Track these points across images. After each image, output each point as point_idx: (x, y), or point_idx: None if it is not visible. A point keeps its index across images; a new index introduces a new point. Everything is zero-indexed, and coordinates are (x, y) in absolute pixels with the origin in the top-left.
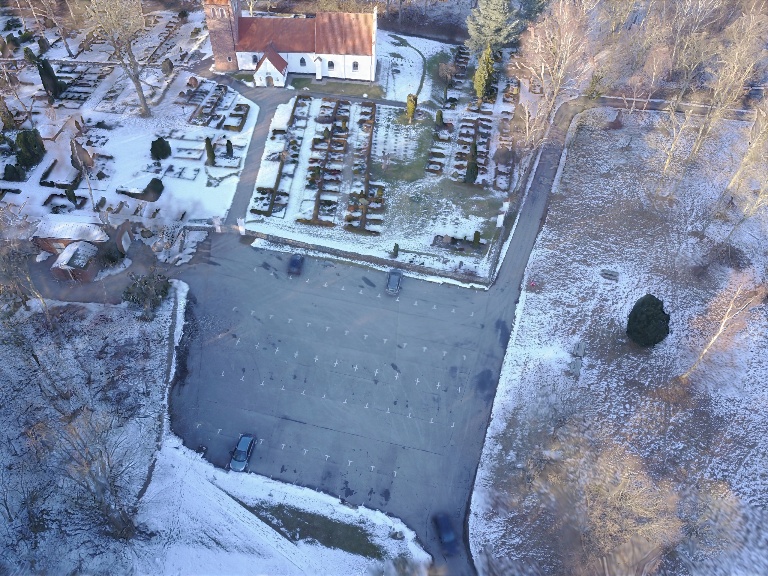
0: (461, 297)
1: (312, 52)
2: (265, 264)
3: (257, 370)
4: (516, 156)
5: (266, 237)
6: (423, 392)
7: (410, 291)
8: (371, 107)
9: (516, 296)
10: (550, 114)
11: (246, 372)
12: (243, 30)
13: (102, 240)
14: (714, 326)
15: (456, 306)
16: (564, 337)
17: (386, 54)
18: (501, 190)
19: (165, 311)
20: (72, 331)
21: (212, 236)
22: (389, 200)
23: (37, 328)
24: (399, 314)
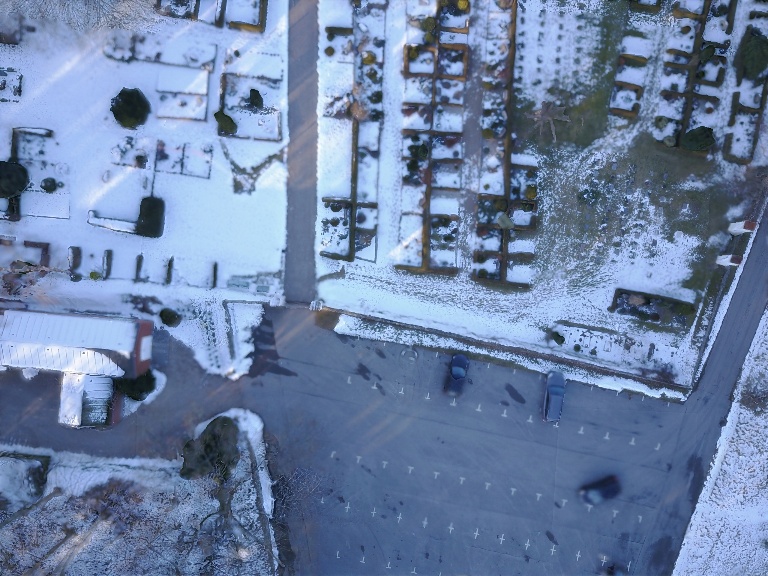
0: (646, 416)
1: None
2: (362, 368)
3: (379, 549)
4: None
5: (356, 315)
6: (585, 572)
7: (574, 407)
8: None
9: (724, 412)
10: None
11: (366, 551)
12: None
13: (115, 375)
14: None
15: (637, 433)
16: None
17: None
18: (737, 161)
19: (242, 473)
20: (131, 518)
21: (271, 314)
22: (545, 202)
23: (84, 515)
24: (558, 451)
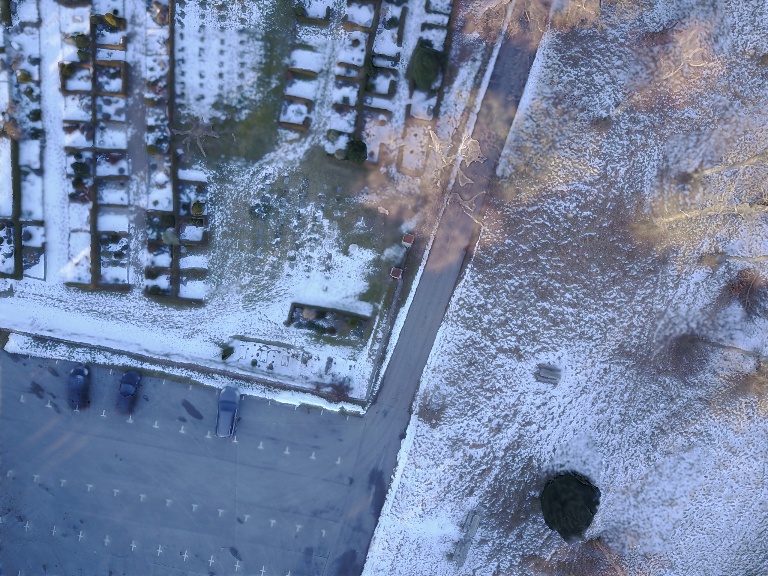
0: (325, 430)
1: None
2: (34, 387)
3: (61, 568)
4: (449, 67)
5: (23, 334)
6: None
7: (253, 422)
8: None
9: (403, 425)
10: None
11: (48, 570)
12: None
13: None
14: (671, 441)
15: (317, 447)
16: (456, 502)
17: None
18: (410, 174)
19: None
20: None
21: None
22: (216, 218)
23: None
24: (237, 467)
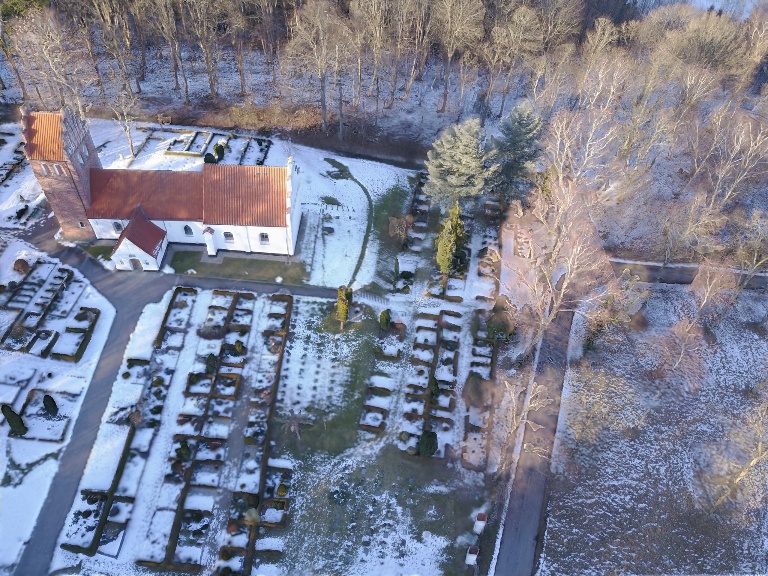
0: None
1: (199, 220)
2: None
3: None
4: (497, 390)
5: None
6: None
7: None
8: (286, 302)
9: None
10: (544, 299)
11: None
12: (97, 187)
13: None
14: None
15: None
16: None
17: (316, 200)
18: (474, 469)
19: None
20: None
21: None
22: (297, 501)
23: None
24: None
